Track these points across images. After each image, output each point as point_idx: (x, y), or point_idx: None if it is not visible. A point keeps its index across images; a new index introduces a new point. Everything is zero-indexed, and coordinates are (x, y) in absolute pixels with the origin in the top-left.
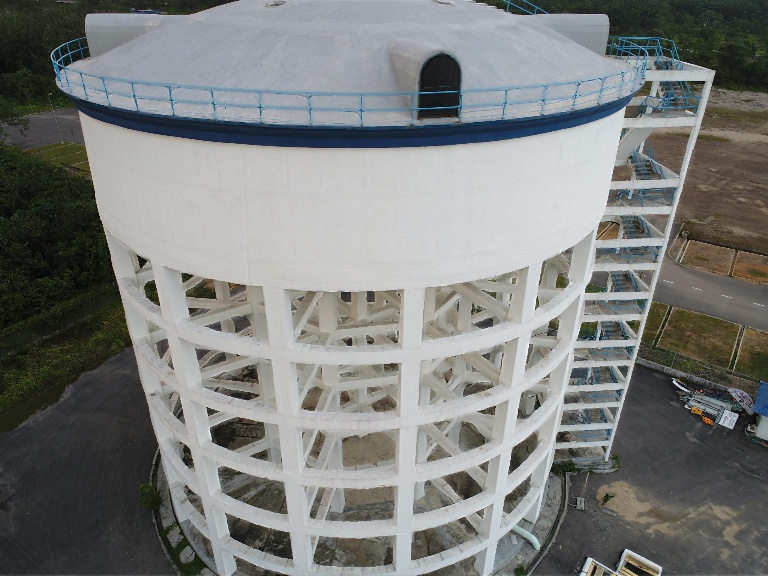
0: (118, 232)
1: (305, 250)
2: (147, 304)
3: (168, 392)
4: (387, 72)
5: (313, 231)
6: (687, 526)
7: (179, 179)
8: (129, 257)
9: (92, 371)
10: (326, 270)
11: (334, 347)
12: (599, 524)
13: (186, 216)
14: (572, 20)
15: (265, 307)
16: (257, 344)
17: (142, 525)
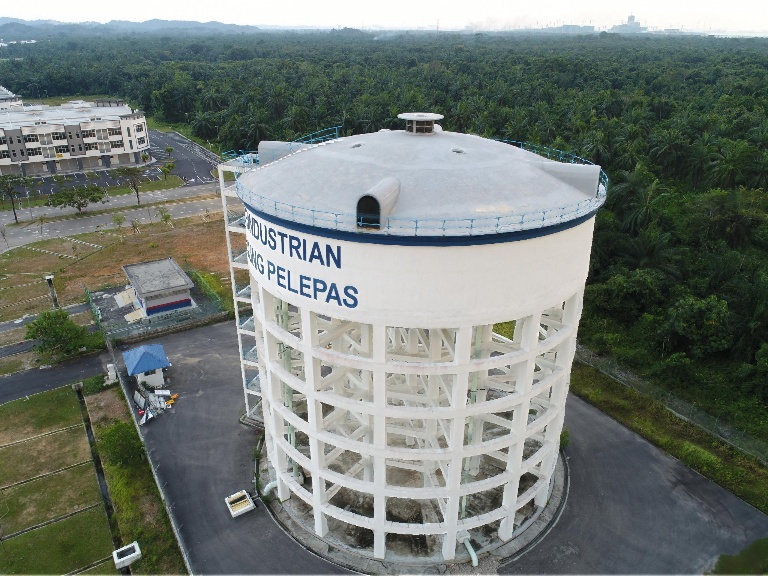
0: None
1: None
2: None
3: None
4: None
5: None
6: None
7: None
8: None
9: None
10: None
11: None
12: None
13: None
14: None
15: None
16: None
17: None
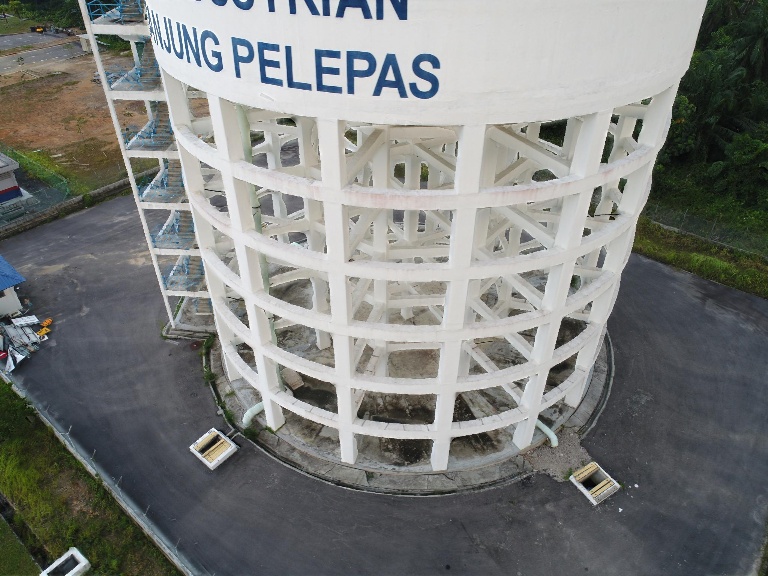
0: None
1: None
2: None
3: None
4: None
5: None
6: None
7: None
8: None
9: None
10: None
11: None
12: None
13: None
14: None
15: None
16: None
17: None
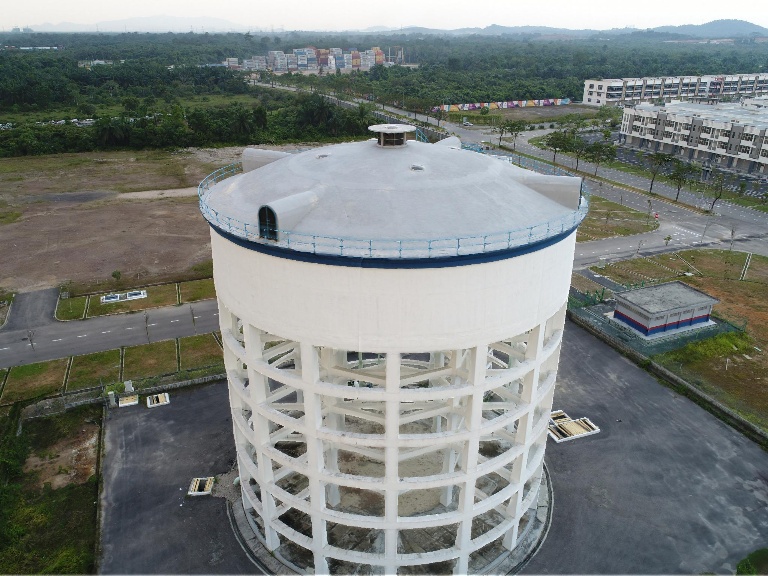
0: (438, 344)
1: None
2: (449, 388)
3: None
4: (538, 193)
5: (558, 281)
6: None
7: (513, 281)
8: None
9: None
10: None
11: (548, 345)
12: None
13: (513, 302)
14: (451, 143)
15: (539, 336)
16: (530, 363)
17: None
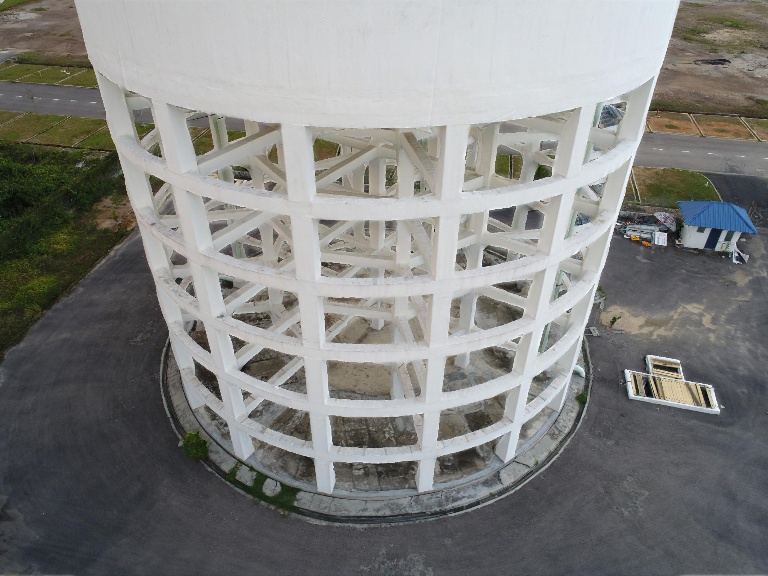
0: (211, 99)
1: (501, 70)
2: (251, 191)
3: (230, 312)
4: None
5: (514, 45)
6: (677, 325)
7: None
8: (190, 143)
9: (17, 346)
10: (519, 93)
11: (503, 189)
12: (616, 343)
13: (354, 48)
14: None
15: (445, 151)
16: (425, 201)
17: (199, 478)
